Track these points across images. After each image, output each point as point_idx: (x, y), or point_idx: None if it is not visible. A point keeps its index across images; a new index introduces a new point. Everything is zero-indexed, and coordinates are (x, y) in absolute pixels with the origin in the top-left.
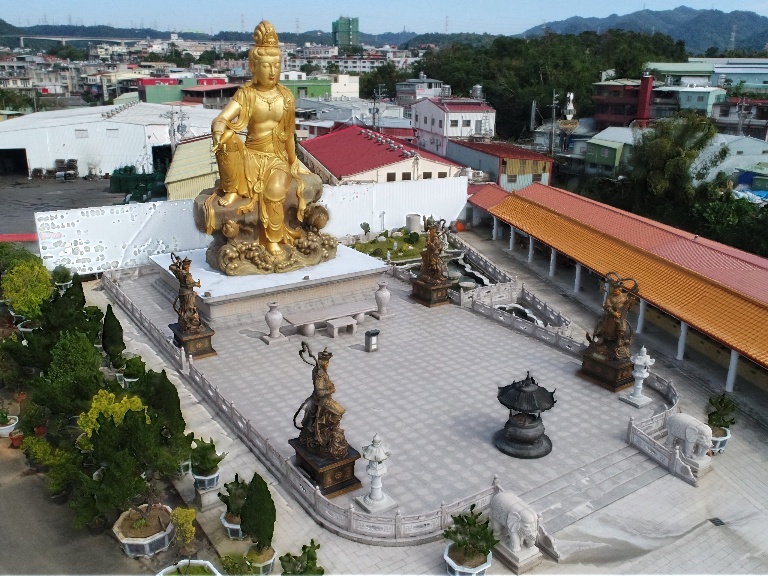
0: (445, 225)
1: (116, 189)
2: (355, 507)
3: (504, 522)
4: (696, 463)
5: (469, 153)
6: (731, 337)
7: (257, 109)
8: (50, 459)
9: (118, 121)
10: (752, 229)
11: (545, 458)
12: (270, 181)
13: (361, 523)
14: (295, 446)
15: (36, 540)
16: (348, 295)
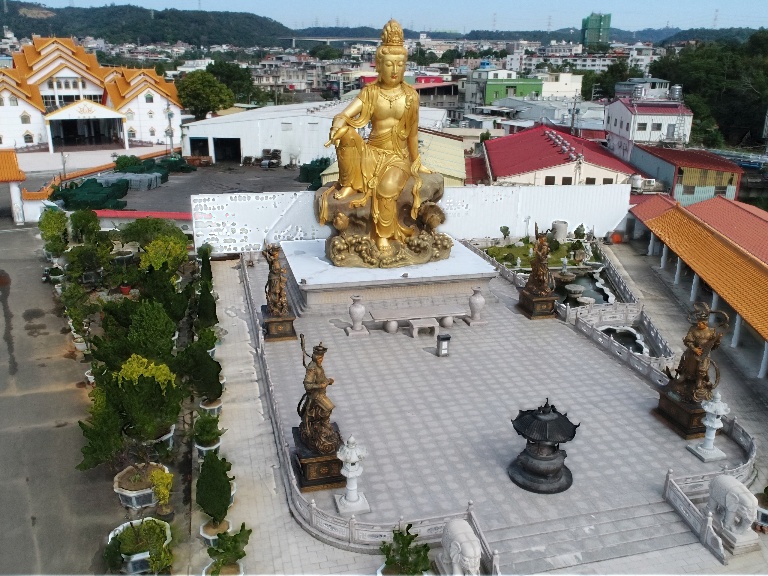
0: (600, 235)
1: (304, 178)
2: (330, 504)
3: (449, 550)
4: (733, 537)
5: (650, 159)
6: None
7: (379, 107)
8: (92, 408)
9: (319, 116)
10: None
11: (555, 495)
12: (384, 177)
13: (320, 520)
14: (294, 434)
15: (65, 475)
16: (450, 297)
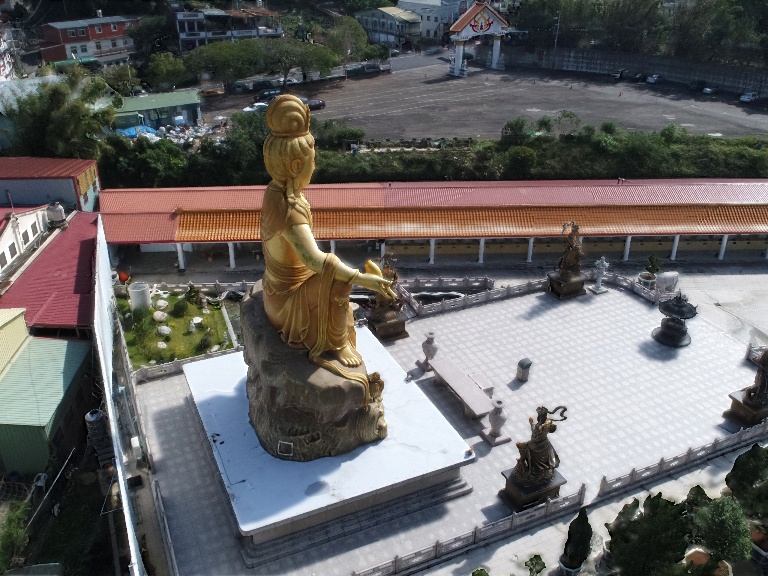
0: None
1: None
2: None
3: None
4: None
5: None
6: (584, 230)
7: None
8: None
9: None
10: (215, 164)
11: (688, 333)
12: None
13: None
14: (764, 410)
15: None
16: None
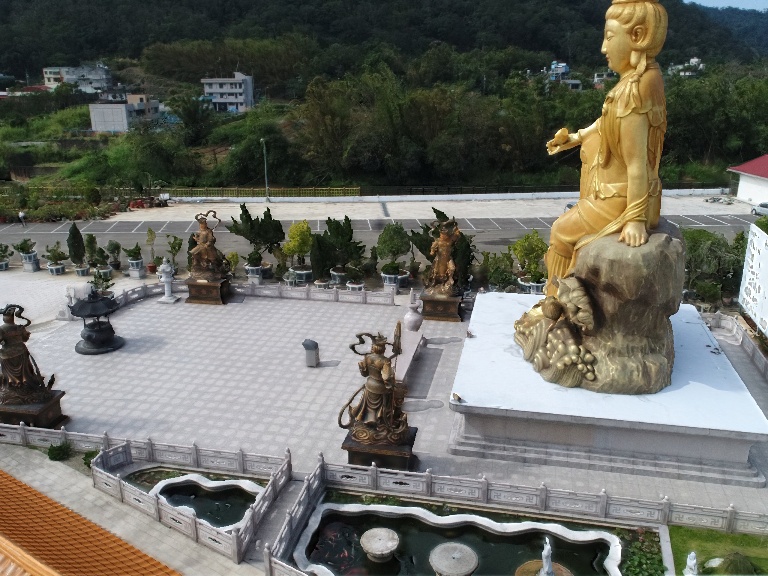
0: None
1: None
2: None
3: None
4: None
5: None
6: None
7: None
8: None
9: None
10: None
11: None
12: None
13: None
14: None
15: None
16: None
